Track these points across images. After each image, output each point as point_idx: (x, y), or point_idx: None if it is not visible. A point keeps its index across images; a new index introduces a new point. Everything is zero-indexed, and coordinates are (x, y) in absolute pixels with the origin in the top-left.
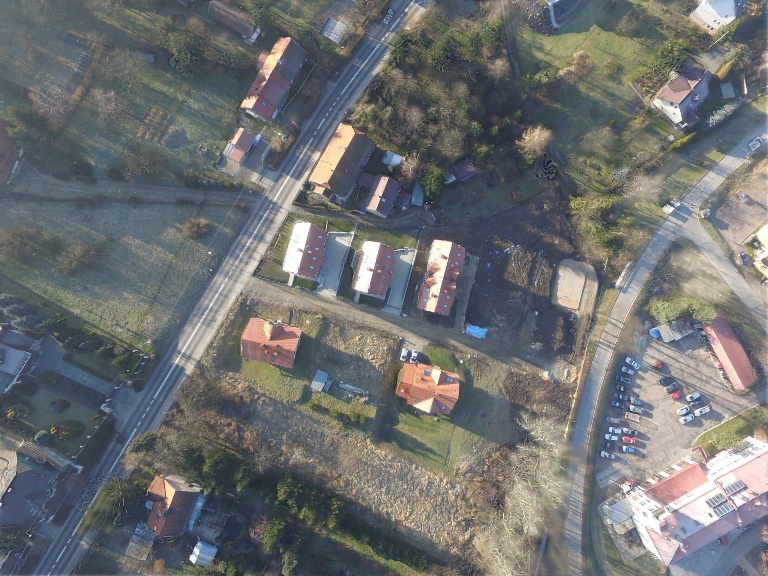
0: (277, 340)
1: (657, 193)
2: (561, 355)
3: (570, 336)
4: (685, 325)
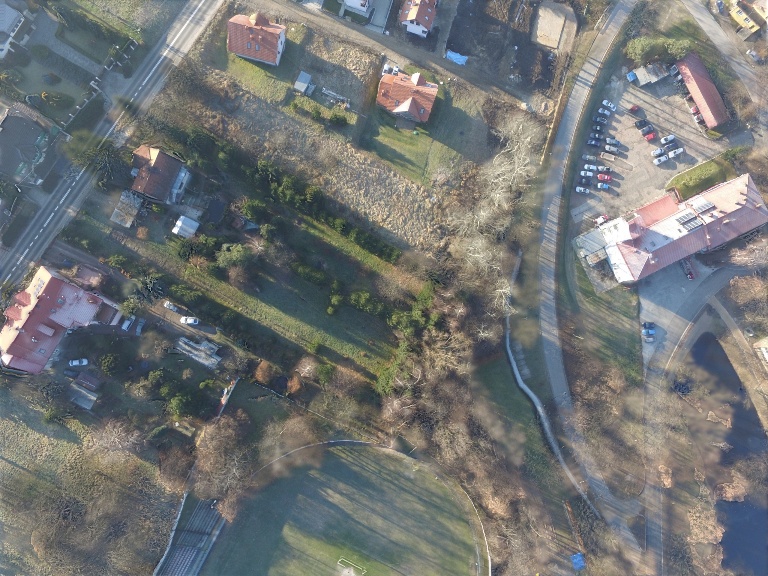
0: (262, 27)
1: None
2: (539, 89)
3: (548, 73)
4: (661, 68)
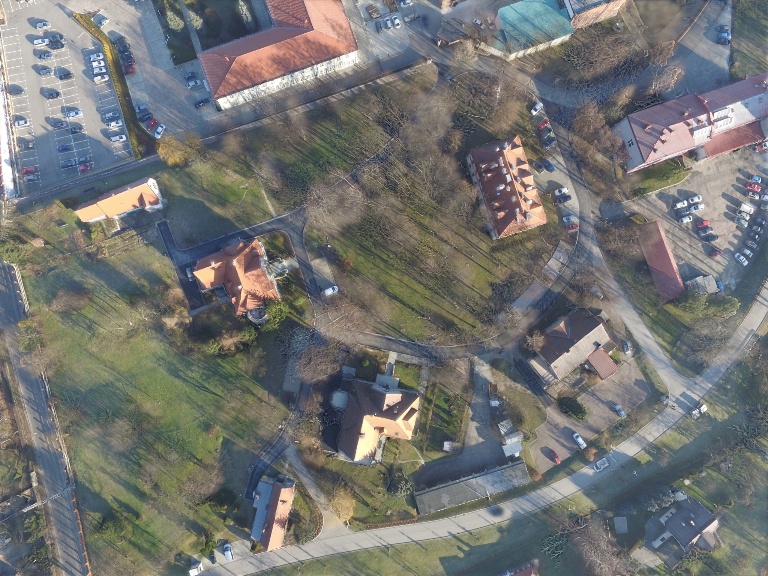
0: None
1: (705, 426)
2: None
3: None
4: None
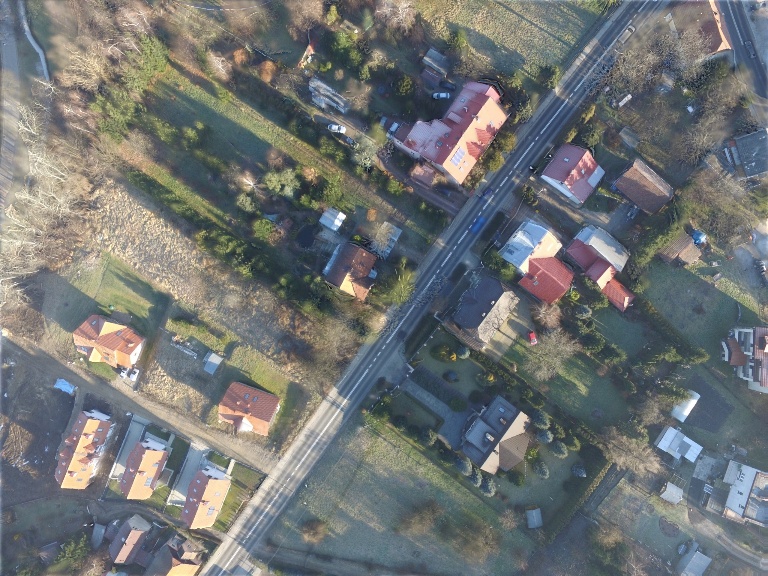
0: (237, 415)
1: None
2: None
3: None
4: None
